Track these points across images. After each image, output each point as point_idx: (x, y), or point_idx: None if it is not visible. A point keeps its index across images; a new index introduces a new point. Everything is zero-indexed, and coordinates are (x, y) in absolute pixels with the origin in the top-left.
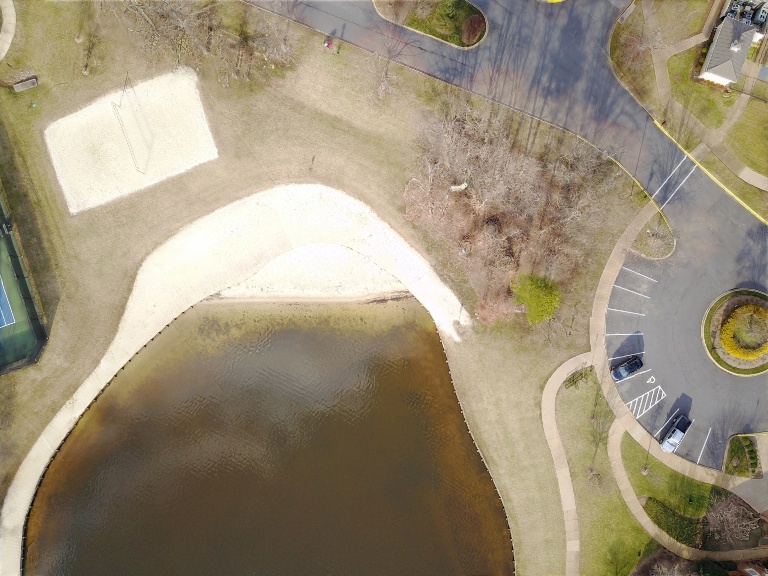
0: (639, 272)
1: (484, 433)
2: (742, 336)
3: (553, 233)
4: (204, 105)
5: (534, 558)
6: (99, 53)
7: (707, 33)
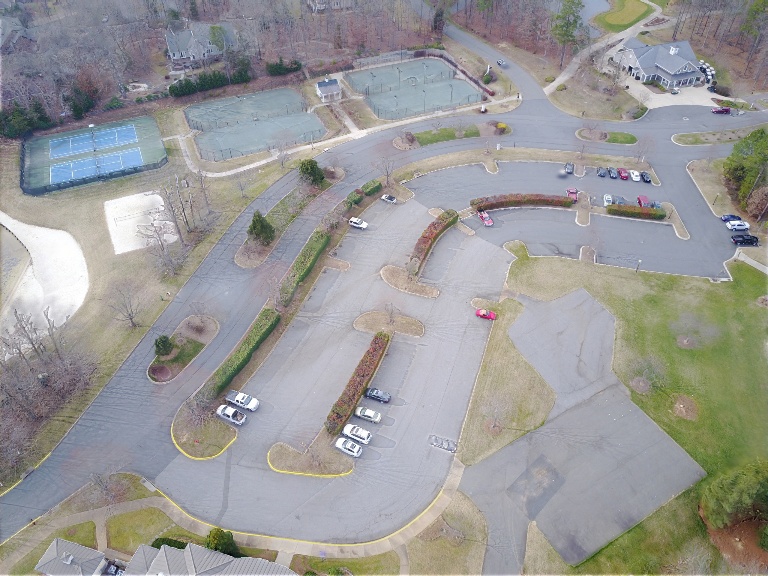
0: None
1: None
2: None
3: None
4: (151, 247)
5: None
6: None
7: (106, 553)
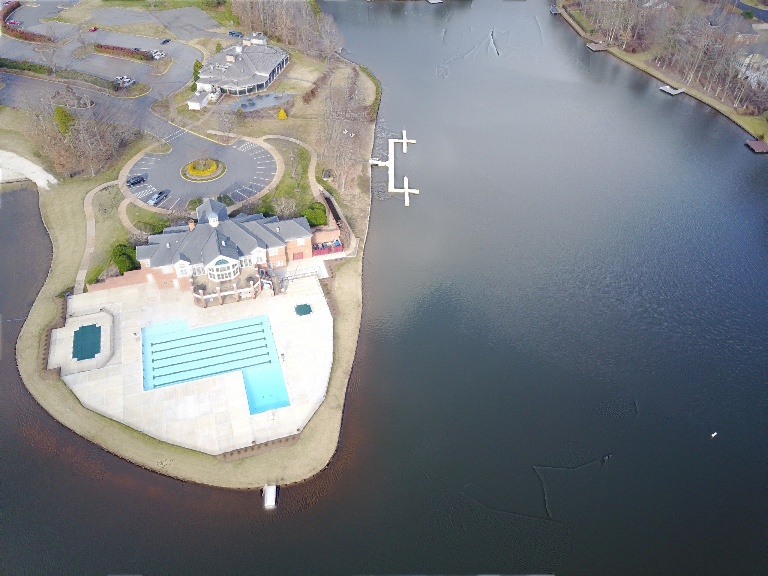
0: None
1: (50, 218)
2: None
3: None
4: None
5: (64, 260)
6: None
7: None
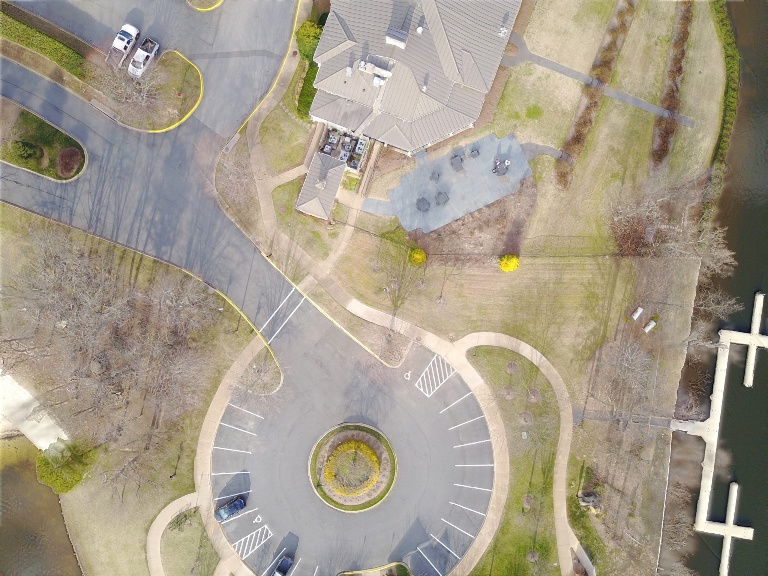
0: (245, 409)
1: (97, 575)
2: (346, 473)
3: None
4: None
5: None
6: None
7: (309, 164)
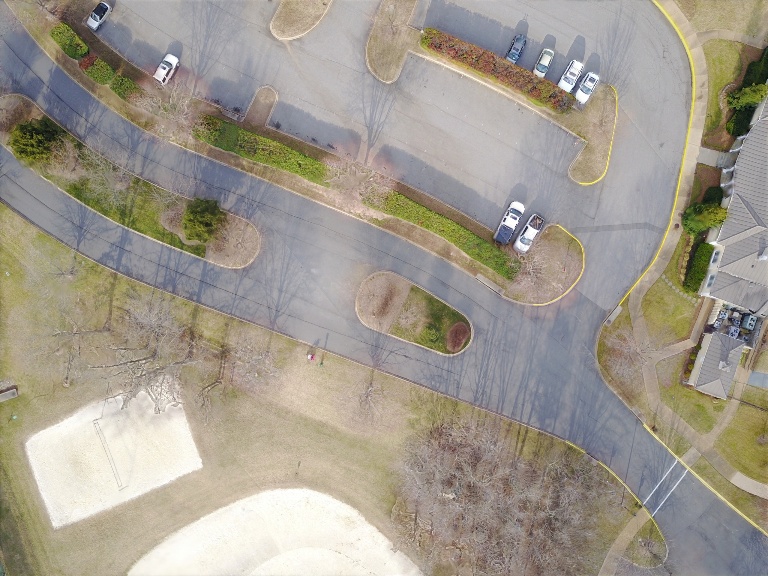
0: None
1: None
2: None
3: (544, 539)
4: (187, 414)
5: None
6: (79, 365)
7: (695, 339)
